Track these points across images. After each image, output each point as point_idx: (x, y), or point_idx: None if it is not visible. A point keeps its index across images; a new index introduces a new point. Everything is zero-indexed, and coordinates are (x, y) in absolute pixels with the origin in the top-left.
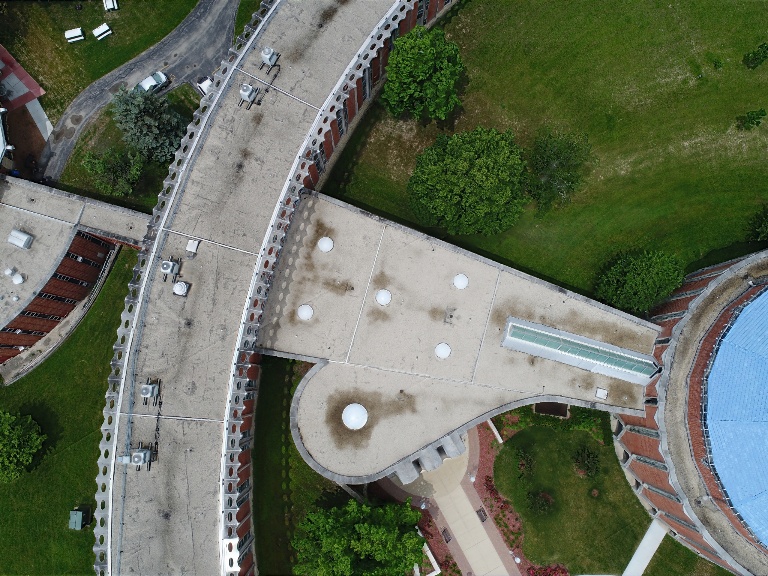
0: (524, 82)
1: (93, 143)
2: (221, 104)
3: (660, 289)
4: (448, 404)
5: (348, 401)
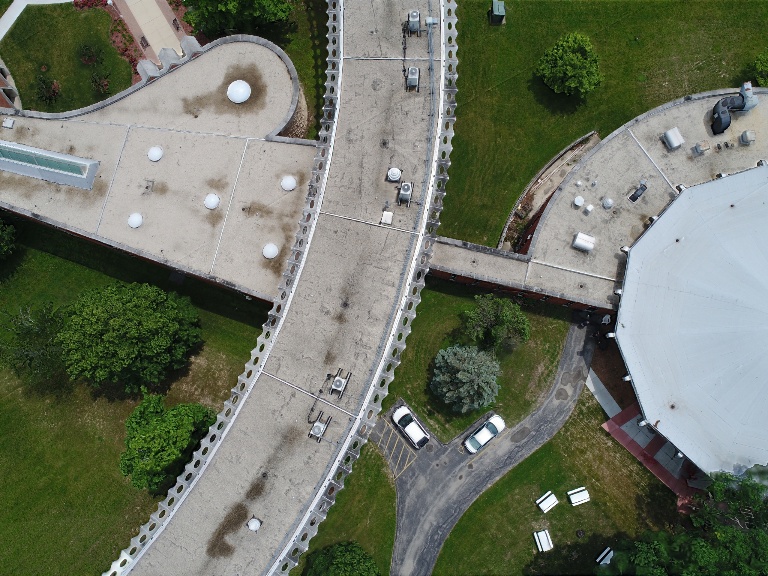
0: (75, 469)
1: (539, 368)
2: (370, 373)
3: None
4: (153, 107)
5: (246, 105)
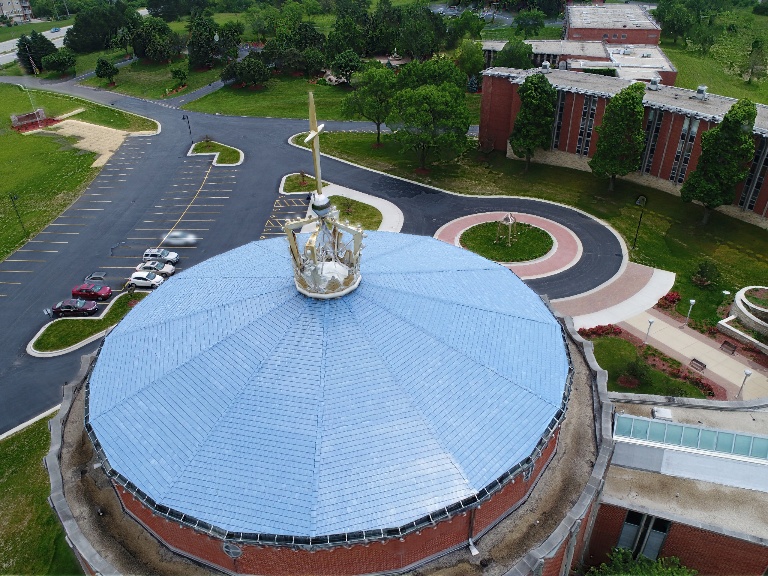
0: None
1: None
2: None
3: (623, 570)
4: None
5: None
